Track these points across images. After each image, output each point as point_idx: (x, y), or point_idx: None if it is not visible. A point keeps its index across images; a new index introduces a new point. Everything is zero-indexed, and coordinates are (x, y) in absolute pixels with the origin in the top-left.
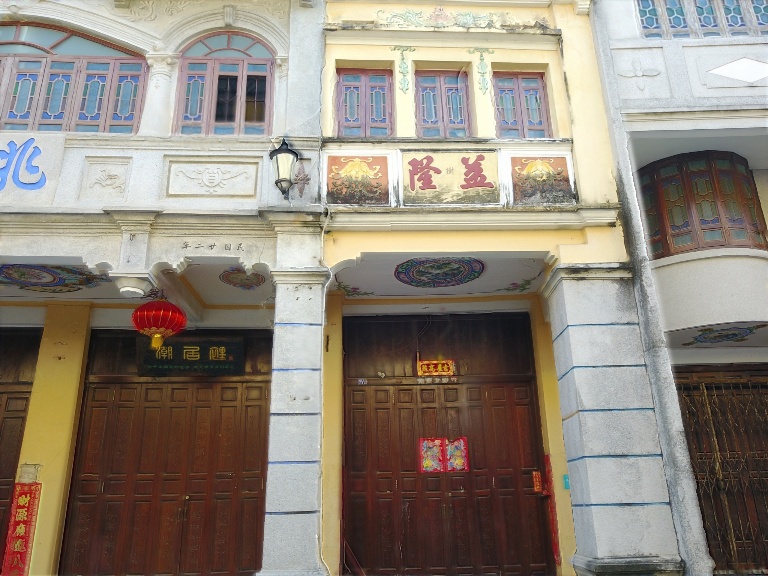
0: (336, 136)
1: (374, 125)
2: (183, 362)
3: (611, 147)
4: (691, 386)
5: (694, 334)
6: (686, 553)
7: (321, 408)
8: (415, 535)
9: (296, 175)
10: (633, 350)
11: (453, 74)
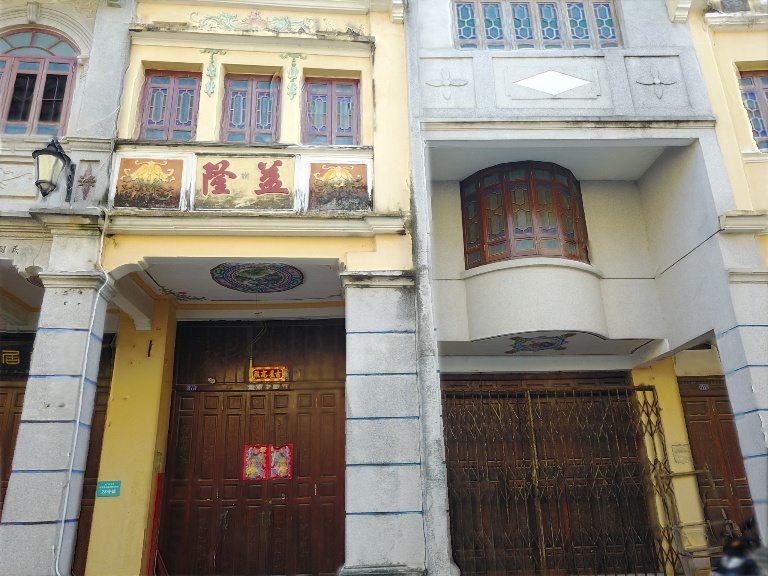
0: (136, 138)
1: (178, 128)
2: (2, 366)
3: (409, 155)
4: (516, 394)
5: (508, 342)
6: (428, 562)
7: (77, 415)
8: (231, 543)
9: (81, 177)
10: (407, 358)
11: (266, 79)
